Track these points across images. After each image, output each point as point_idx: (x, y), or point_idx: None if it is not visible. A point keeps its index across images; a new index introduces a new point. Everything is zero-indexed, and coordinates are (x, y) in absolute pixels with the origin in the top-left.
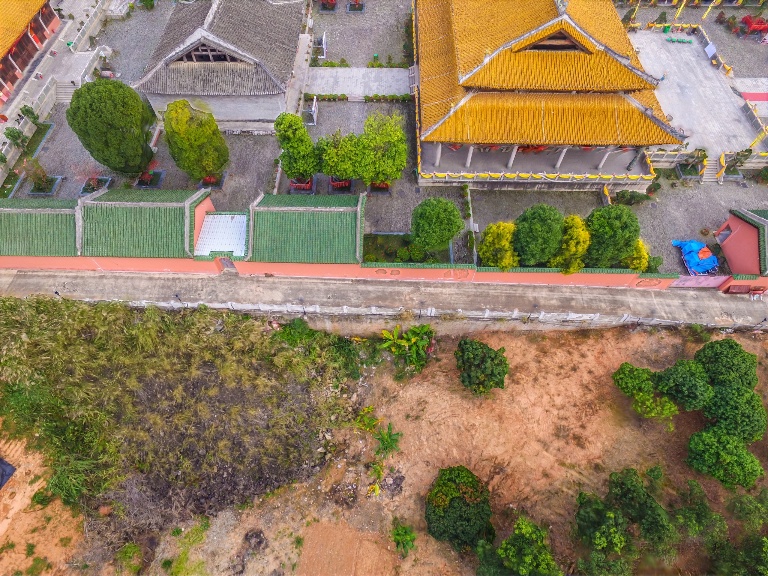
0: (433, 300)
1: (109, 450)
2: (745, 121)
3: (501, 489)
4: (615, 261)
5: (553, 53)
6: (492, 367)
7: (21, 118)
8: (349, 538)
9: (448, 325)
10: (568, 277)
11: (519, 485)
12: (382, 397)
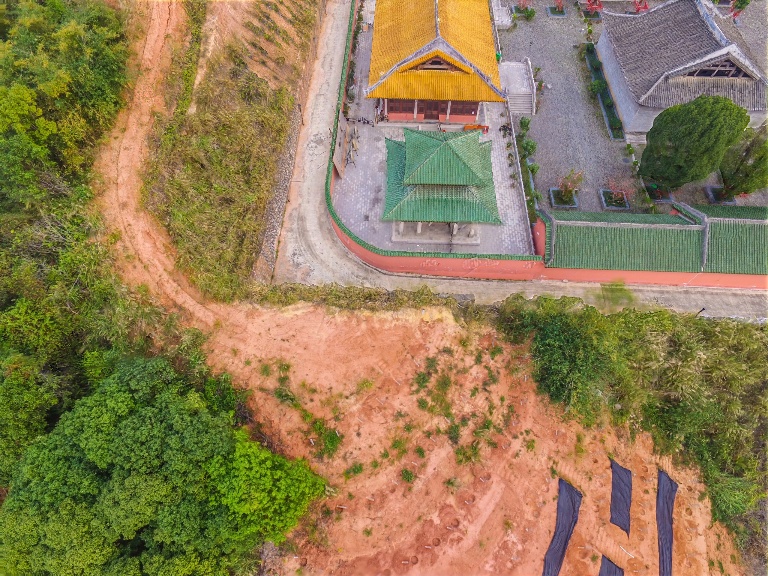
0: None
1: (754, 467)
2: None
3: None
4: None
5: None
6: None
7: (503, 129)
8: None
9: None
10: None
11: None
12: None
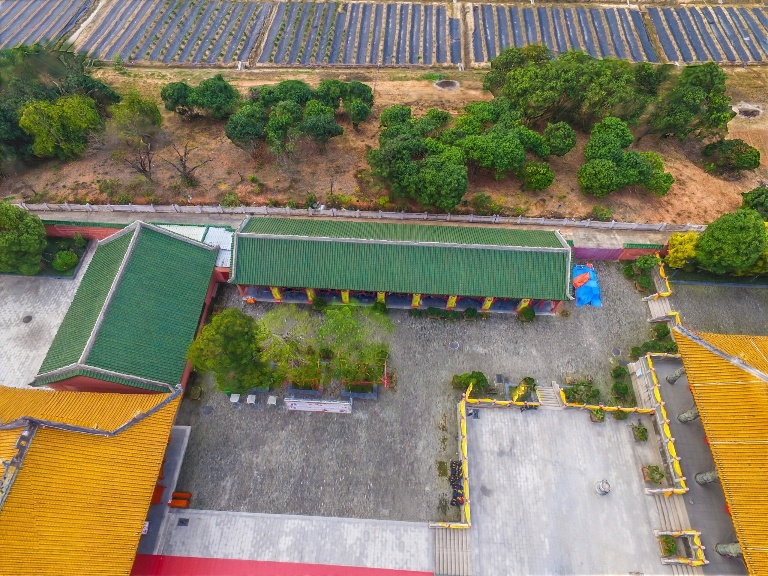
0: None
1: None
2: (474, 489)
3: None
4: None
5: None
6: (767, 191)
7: None
8: None
9: None
10: None
11: None
12: None
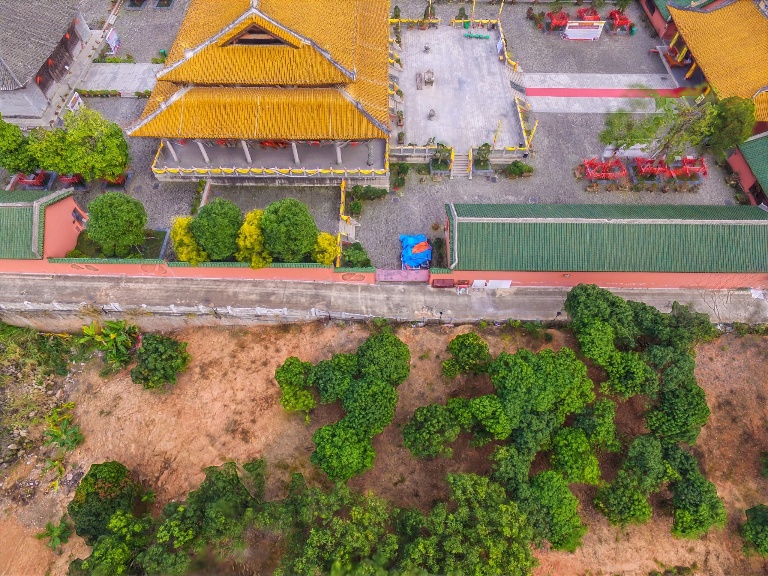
0: (129, 295)
1: None
2: (511, 116)
3: (167, 484)
4: (299, 255)
5: (260, 47)
6: (156, 362)
7: None
8: (13, 535)
9: (146, 320)
10: (262, 272)
11: (180, 480)
12: (85, 393)
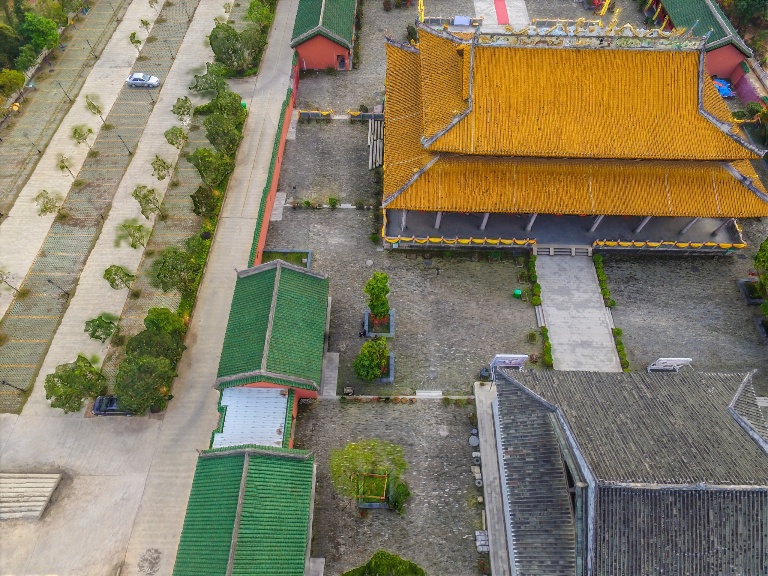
0: None
1: None
2: None
3: None
4: None
5: None
6: None
7: None
8: None
9: None
10: None
11: None
12: None
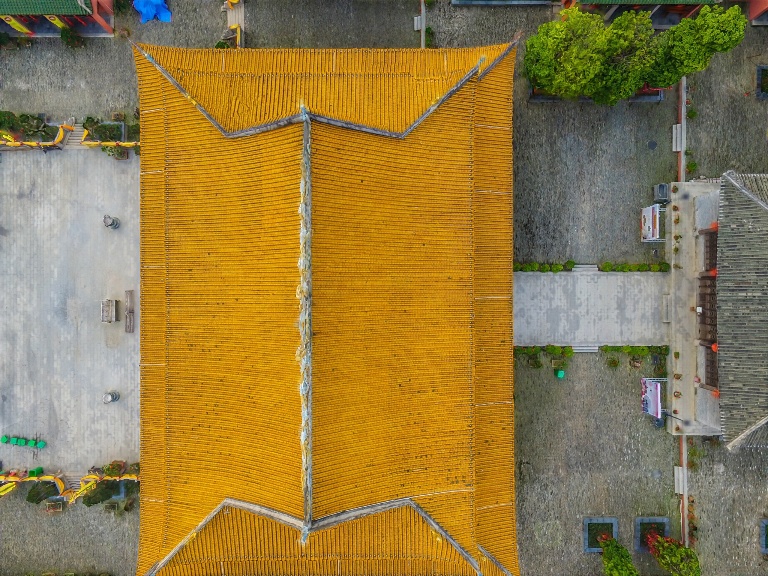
0: None
1: None
2: None
3: None
4: None
5: None
6: None
7: None
8: None
9: None
10: None
11: None
12: None
